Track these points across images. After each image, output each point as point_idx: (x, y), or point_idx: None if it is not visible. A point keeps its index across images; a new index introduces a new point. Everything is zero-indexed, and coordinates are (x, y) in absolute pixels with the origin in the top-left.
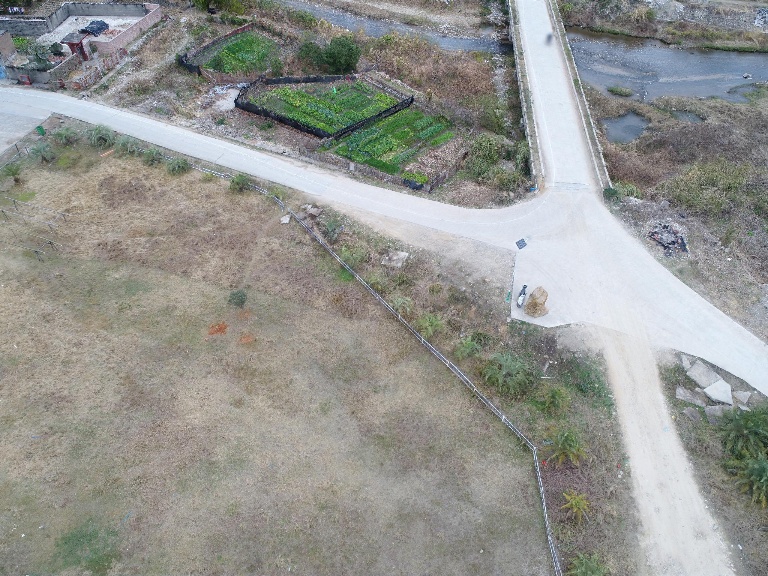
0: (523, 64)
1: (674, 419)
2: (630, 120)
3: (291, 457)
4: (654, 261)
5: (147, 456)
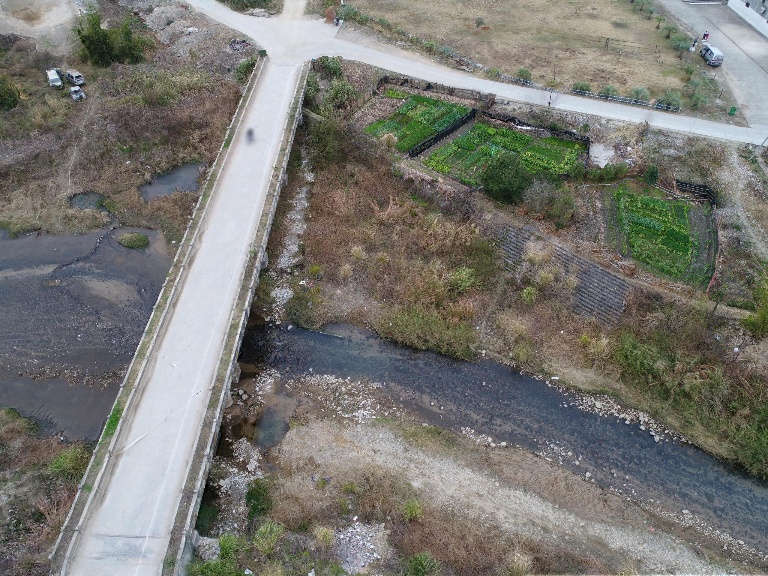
0: None
1: (282, 8)
2: (160, 192)
3: (433, 4)
4: None
5: (487, 3)
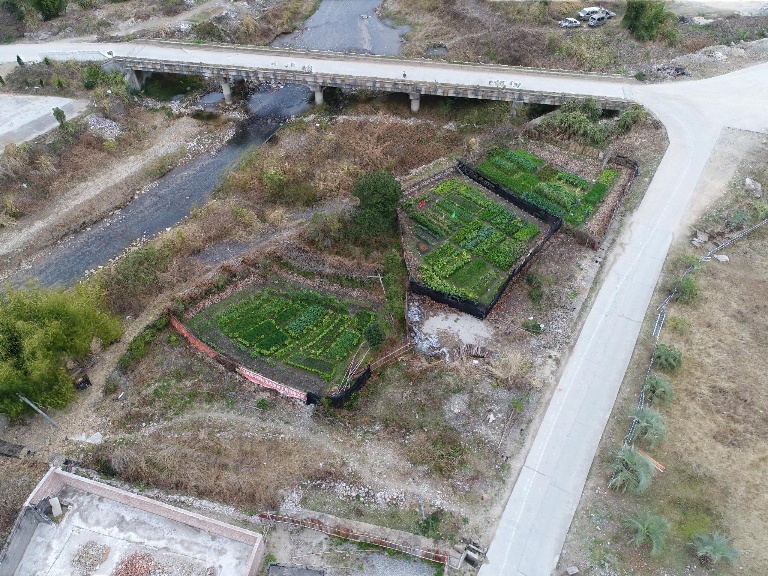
0: (416, 81)
1: None
2: None
3: None
4: (698, 81)
5: None
